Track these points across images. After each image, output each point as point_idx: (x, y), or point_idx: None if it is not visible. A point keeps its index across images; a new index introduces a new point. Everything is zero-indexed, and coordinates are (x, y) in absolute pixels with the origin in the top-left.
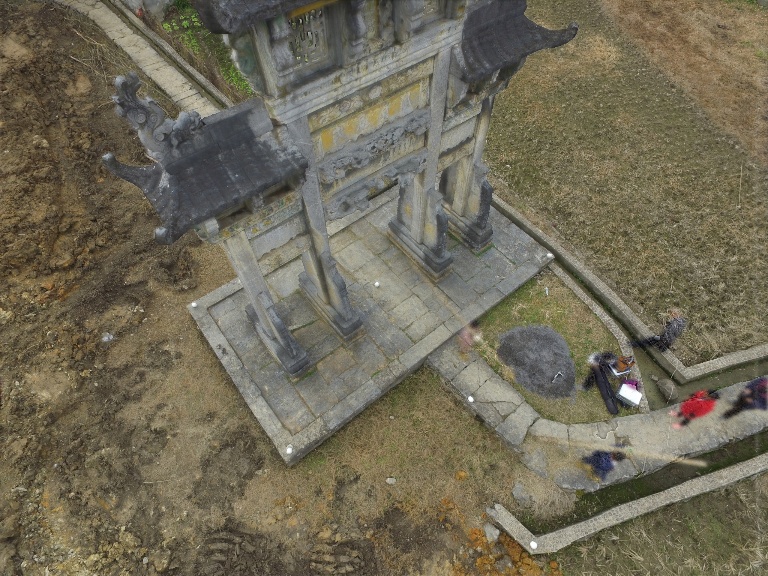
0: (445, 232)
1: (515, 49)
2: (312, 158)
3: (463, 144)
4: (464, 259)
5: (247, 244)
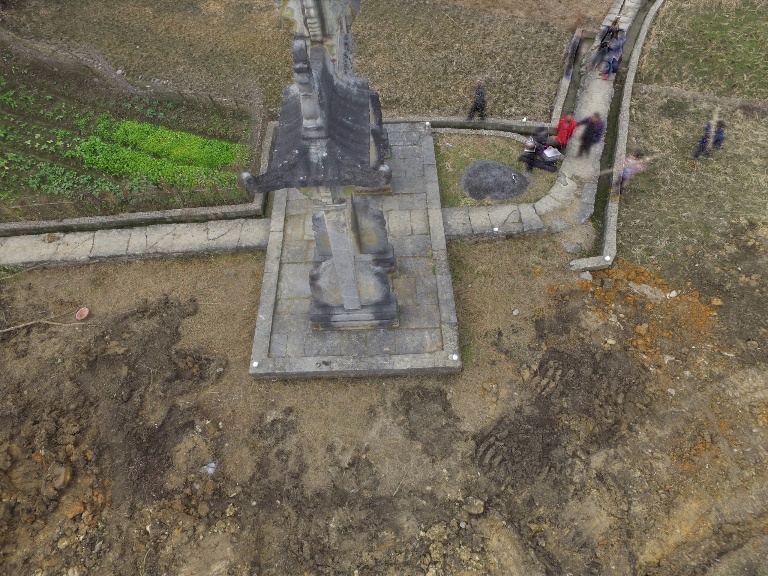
0: None
1: None
2: None
3: None
4: None
5: None
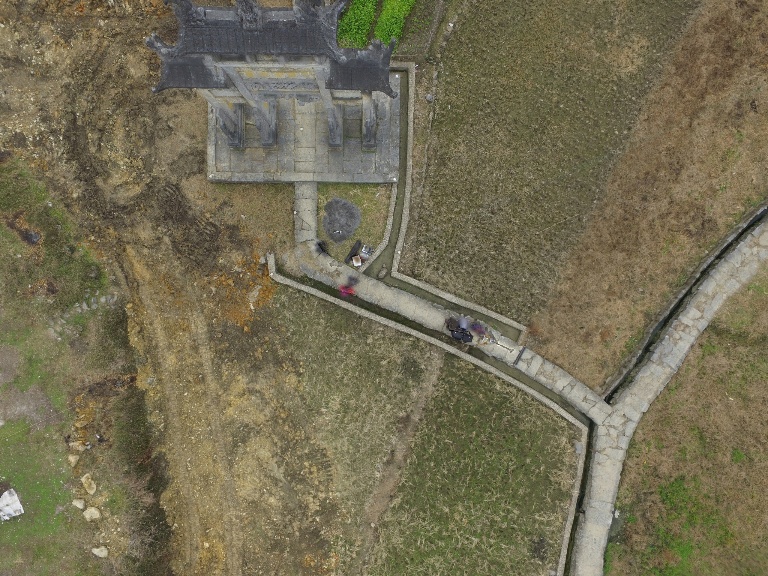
0: (333, 132)
1: (363, 84)
2: None
3: (353, 99)
4: (354, 148)
5: (207, 92)
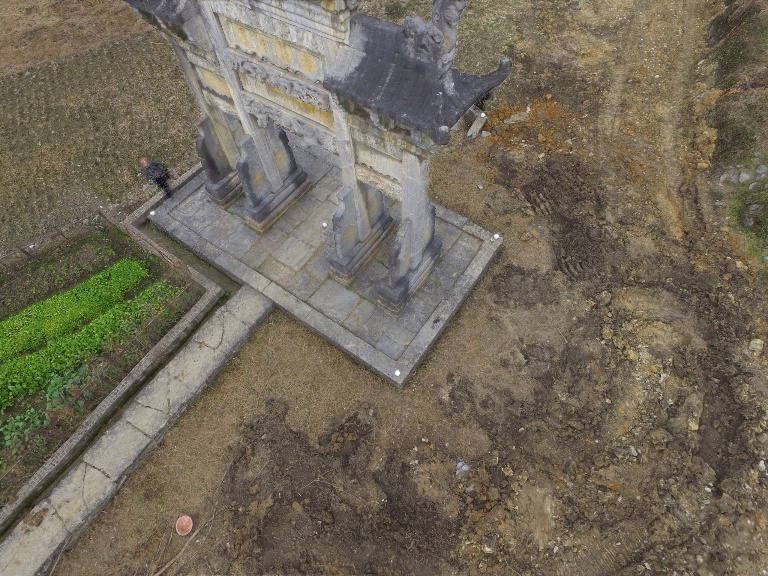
0: None
1: None
2: None
3: None
4: None
5: None
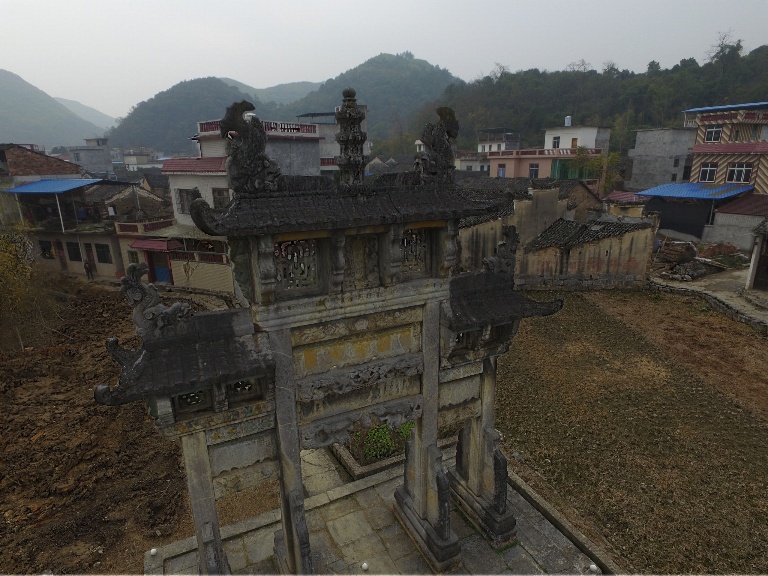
0: (447, 502)
1: (504, 312)
2: (291, 372)
3: (467, 403)
4: (480, 553)
5: (204, 450)
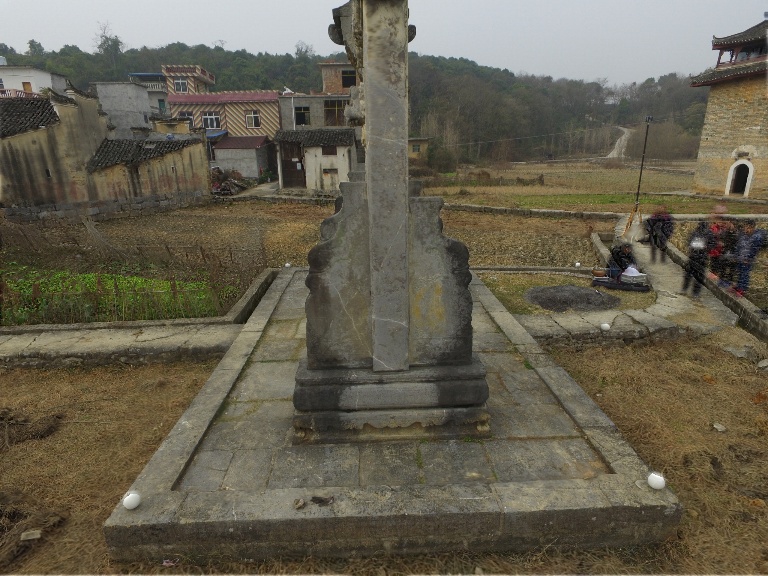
0: None
1: None
2: None
3: None
4: None
5: None
